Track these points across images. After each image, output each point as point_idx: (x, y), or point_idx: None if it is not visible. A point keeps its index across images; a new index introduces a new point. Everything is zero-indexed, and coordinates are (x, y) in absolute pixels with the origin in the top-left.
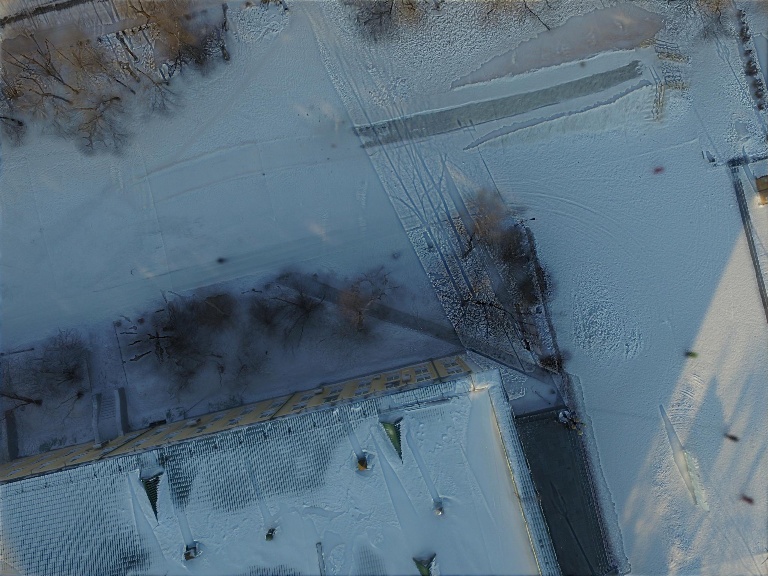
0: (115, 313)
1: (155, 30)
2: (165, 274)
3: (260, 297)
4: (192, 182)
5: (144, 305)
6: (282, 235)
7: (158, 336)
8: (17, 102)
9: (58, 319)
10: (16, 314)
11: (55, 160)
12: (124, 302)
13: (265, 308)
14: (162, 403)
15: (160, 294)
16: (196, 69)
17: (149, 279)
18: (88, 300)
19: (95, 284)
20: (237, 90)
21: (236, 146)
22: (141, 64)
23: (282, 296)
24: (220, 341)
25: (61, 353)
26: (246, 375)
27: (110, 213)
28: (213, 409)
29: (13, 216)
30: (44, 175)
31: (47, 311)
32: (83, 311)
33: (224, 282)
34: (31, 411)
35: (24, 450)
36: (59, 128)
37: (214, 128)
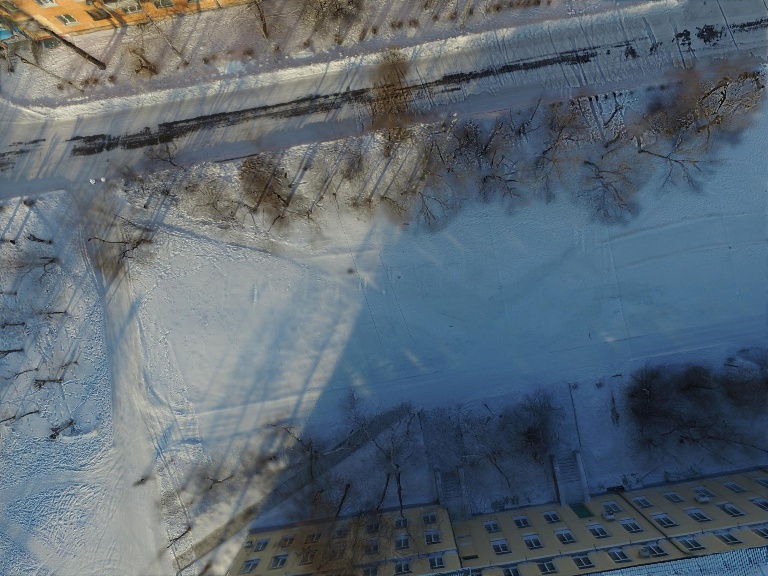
0: (571, 375)
1: (626, 97)
2: (624, 339)
3: (724, 370)
4: (655, 250)
5: (601, 369)
6: (745, 309)
7: (614, 401)
8: (490, 160)
9: (511, 377)
10: (468, 369)
11: (517, 218)
12: (581, 365)
13: (730, 381)
14: (616, 468)
15: (617, 359)
16: (668, 139)
17: (607, 343)
18: (543, 360)
19: (551, 344)
20: (705, 162)
21: (702, 218)
22: (610, 130)
23: (747, 370)
24: (704, 414)
25: (534, 414)
26: (720, 449)
27: (570, 275)
28: (672, 478)
29: (472, 271)
30: (506, 233)
31: (500, 368)
32: (537, 371)
33: (685, 352)
34: (483, 468)
35: (477, 507)
36: (547, 191)
37: (680, 198)
